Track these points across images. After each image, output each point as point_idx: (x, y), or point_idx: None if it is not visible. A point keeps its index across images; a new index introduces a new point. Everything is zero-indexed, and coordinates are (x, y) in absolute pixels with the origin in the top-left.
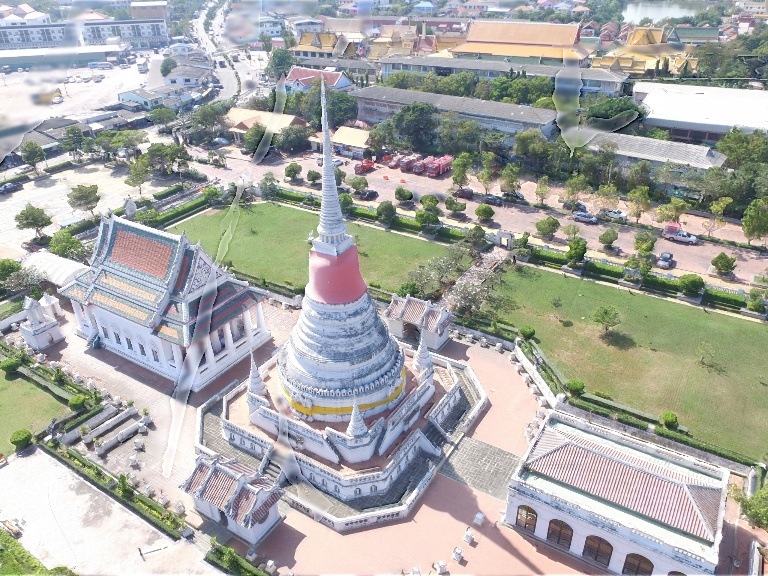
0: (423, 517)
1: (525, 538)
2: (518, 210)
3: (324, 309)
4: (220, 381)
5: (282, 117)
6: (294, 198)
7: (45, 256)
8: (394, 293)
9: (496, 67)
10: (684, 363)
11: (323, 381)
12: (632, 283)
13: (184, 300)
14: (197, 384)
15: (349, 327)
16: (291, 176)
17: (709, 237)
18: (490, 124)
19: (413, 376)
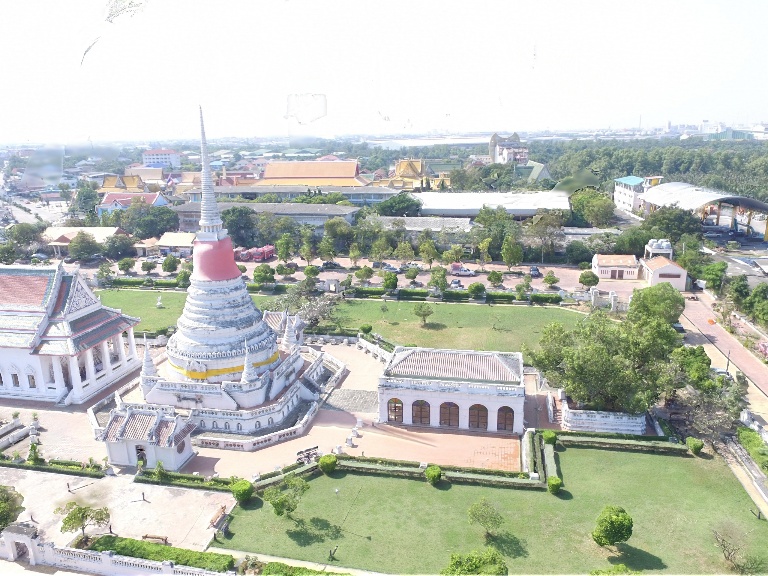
0: (316, 432)
1: (397, 427)
2: (338, 272)
3: (210, 286)
4: (102, 395)
5: (104, 230)
6: (133, 283)
7: None
8: None
9: (295, 189)
10: (483, 330)
11: (215, 346)
12: (436, 298)
13: (65, 319)
14: (81, 396)
15: (232, 300)
16: (125, 269)
17: (483, 270)
18: (301, 220)
19: (285, 352)
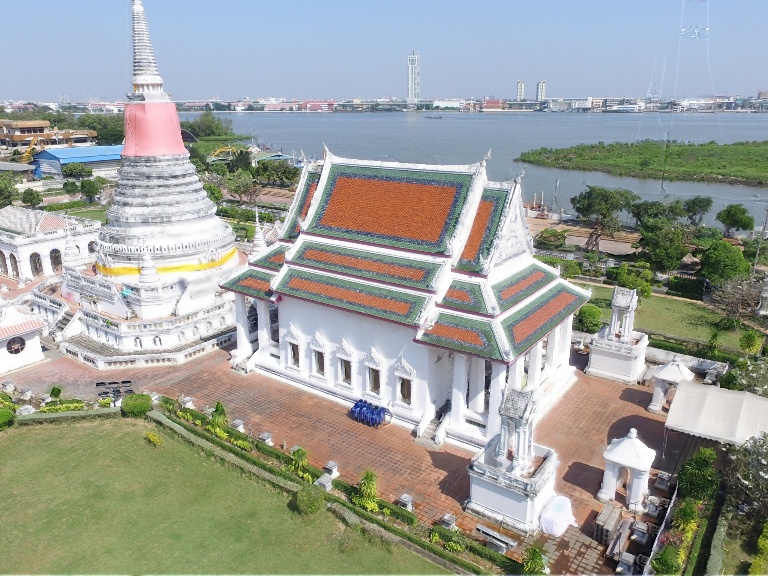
0: None
1: None
2: None
3: None
4: None
5: None
6: None
7: None
8: (7, 304)
9: None
10: None
11: None
12: None
13: None
14: None
15: None
16: None
17: None
18: None
19: None
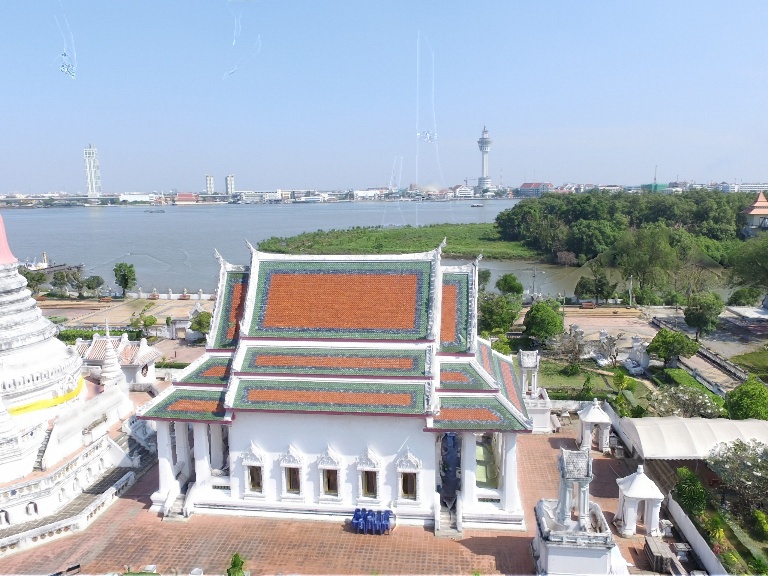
0: None
1: None
2: None
3: None
4: None
5: None
6: None
7: (765, 424)
8: None
9: None
10: None
11: None
12: None
13: None
14: None
15: None
16: None
17: None
18: None
19: None
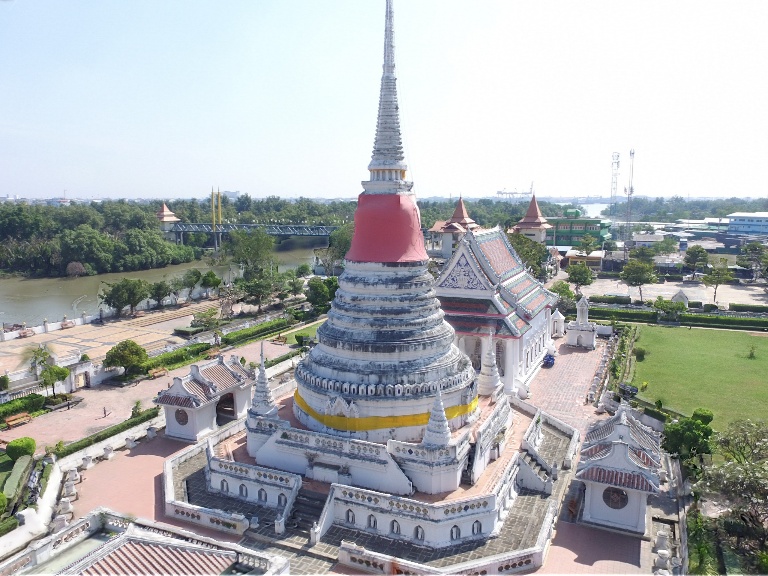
0: None
1: None
2: None
3: None
4: None
5: None
6: None
7: None
8: None
9: None
10: None
11: None
12: None
13: None
14: None
15: None
16: None
17: None
18: None
19: None
